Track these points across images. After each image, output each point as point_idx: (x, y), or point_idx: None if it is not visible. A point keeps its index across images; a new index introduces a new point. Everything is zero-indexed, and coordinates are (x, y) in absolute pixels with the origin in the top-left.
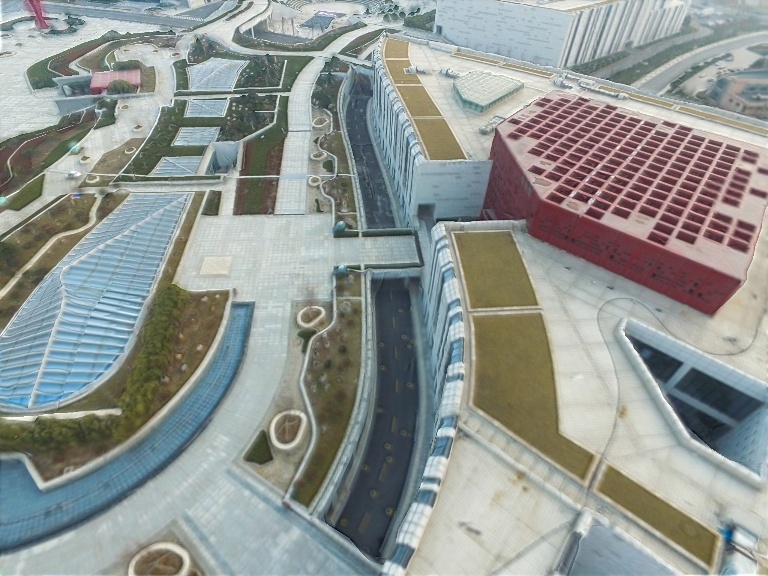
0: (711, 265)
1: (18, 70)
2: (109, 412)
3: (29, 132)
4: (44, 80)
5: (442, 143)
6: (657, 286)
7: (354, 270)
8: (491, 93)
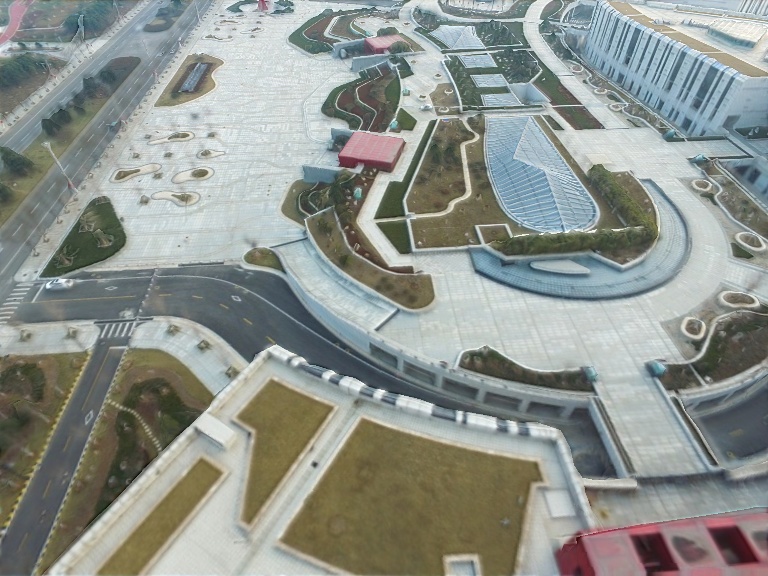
0: None
1: (280, 41)
2: None
3: (344, 83)
4: (319, 46)
5: (745, 68)
6: None
7: (706, 160)
8: (752, 33)
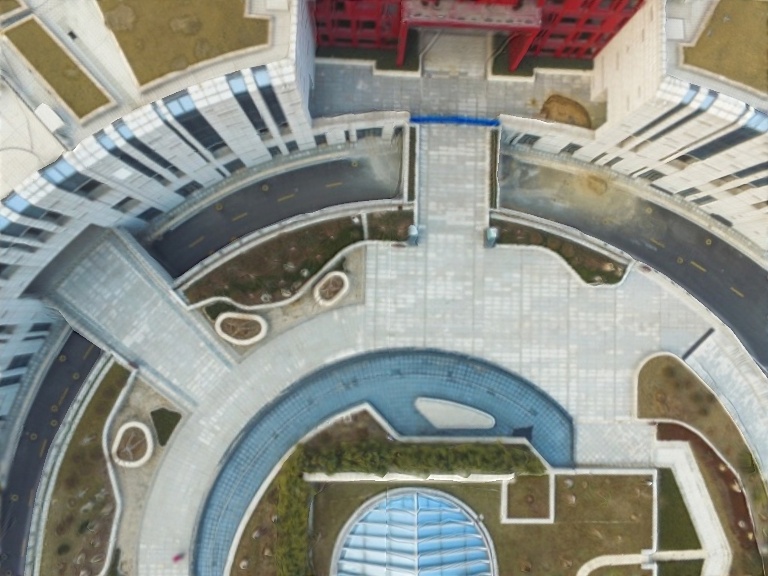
0: None
1: None
2: (315, 477)
3: None
4: None
5: None
6: None
7: None
8: None
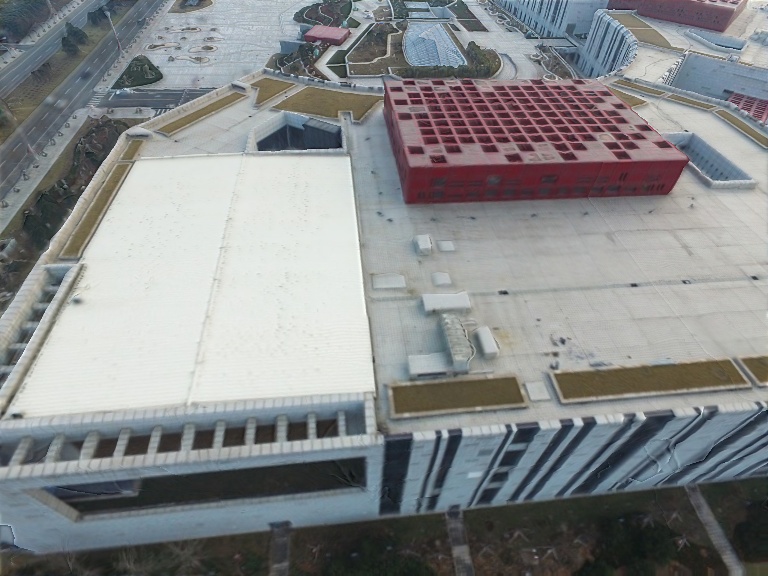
0: (723, 6)
1: None
2: None
3: (310, 5)
4: None
5: None
6: (700, 24)
7: None
8: None
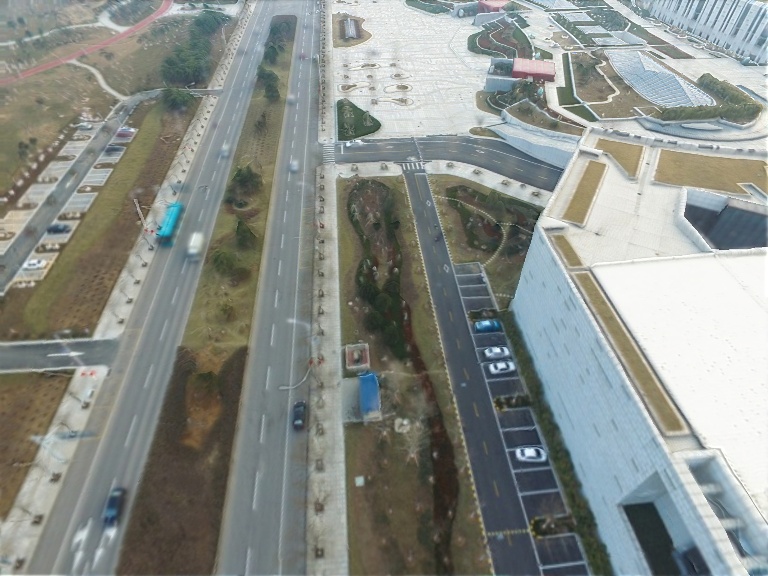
0: None
1: (399, 5)
2: None
3: None
4: (439, 8)
5: None
6: None
7: None
8: None
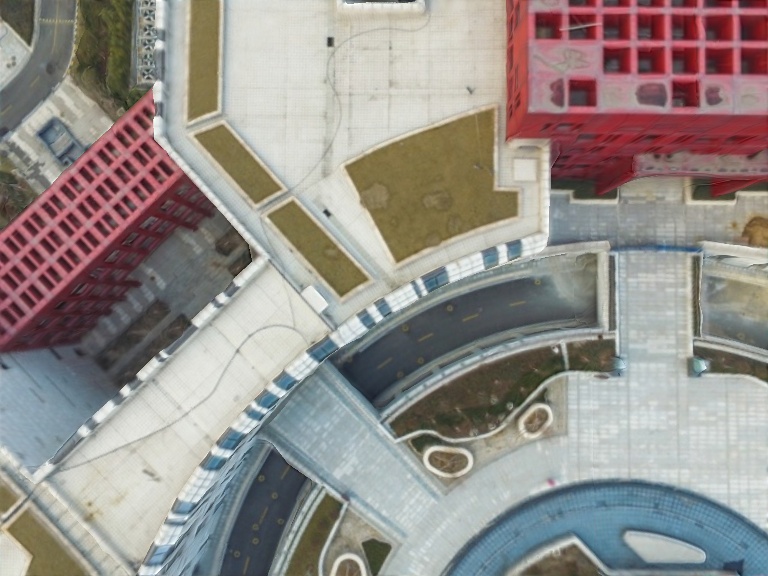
0: None
1: None
2: None
3: None
4: None
5: None
6: None
7: None
8: None
